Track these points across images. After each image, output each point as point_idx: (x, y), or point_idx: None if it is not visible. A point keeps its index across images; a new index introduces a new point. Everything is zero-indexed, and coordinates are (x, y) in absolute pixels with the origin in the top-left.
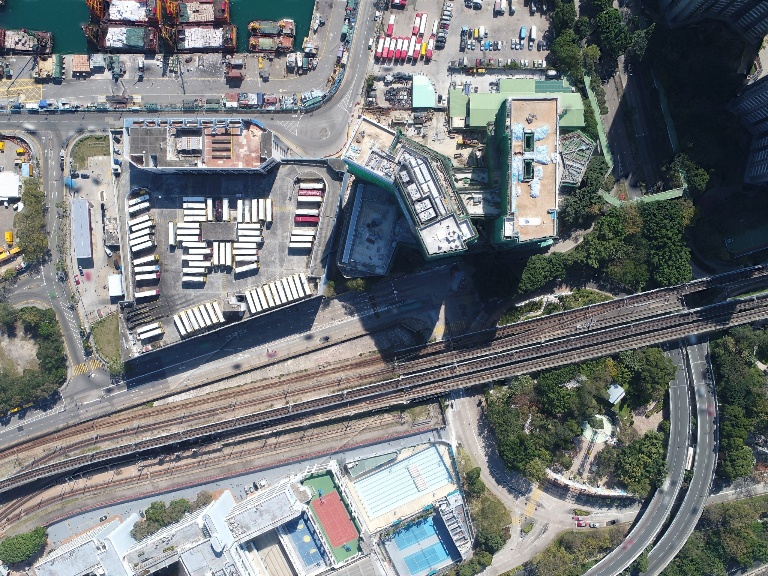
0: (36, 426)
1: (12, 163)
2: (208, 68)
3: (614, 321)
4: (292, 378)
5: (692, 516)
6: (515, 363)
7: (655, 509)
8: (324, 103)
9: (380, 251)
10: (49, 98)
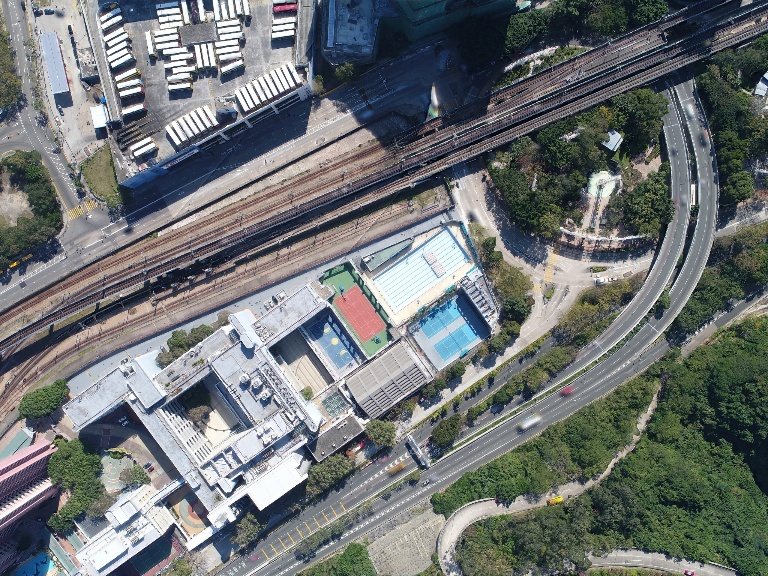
0: (39, 279)
1: None
2: None
3: (602, 68)
4: (295, 181)
5: (704, 249)
6: (513, 127)
7: (668, 248)
8: None
9: (364, 30)
10: None
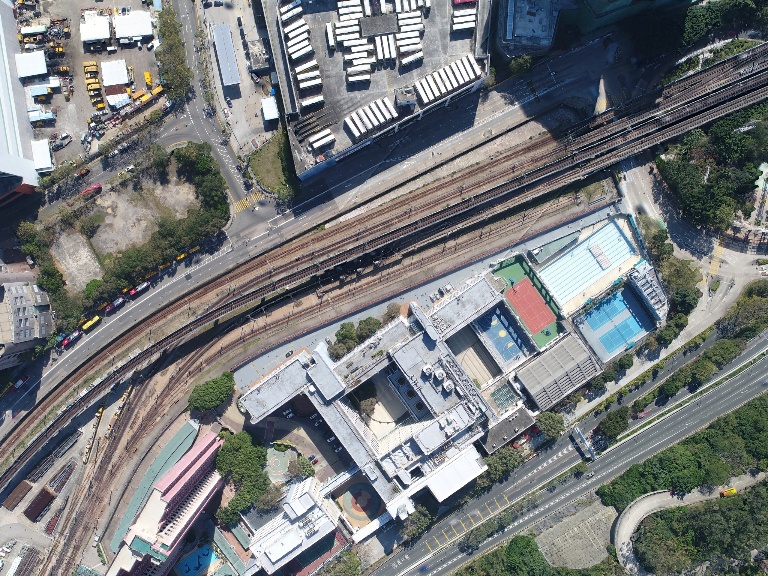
0: (204, 271)
1: (139, 2)
2: None
3: None
4: (465, 174)
5: None
6: (685, 119)
7: None
8: None
9: (542, 22)
10: None
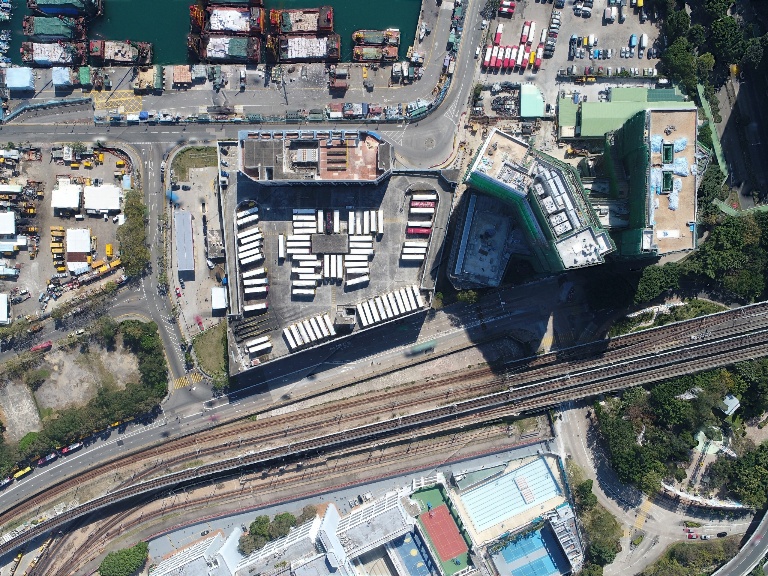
0: (136, 440)
1: (111, 175)
2: (311, 78)
3: (729, 332)
4: (399, 391)
5: None
6: (628, 374)
7: None
8: (430, 113)
9: (493, 262)
10: (149, 109)
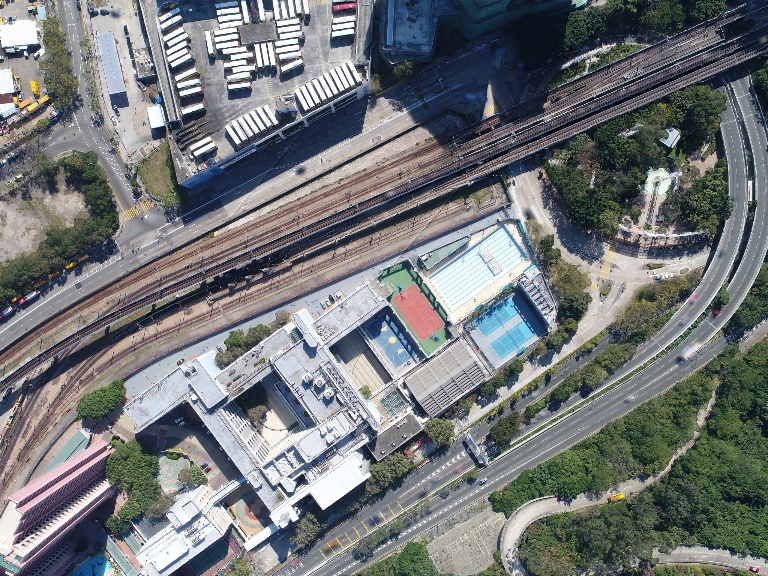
0: (95, 280)
1: (25, 11)
2: None
3: (659, 65)
4: (352, 180)
5: (761, 245)
6: (570, 124)
7: (726, 245)
8: None
9: (423, 29)
10: None
